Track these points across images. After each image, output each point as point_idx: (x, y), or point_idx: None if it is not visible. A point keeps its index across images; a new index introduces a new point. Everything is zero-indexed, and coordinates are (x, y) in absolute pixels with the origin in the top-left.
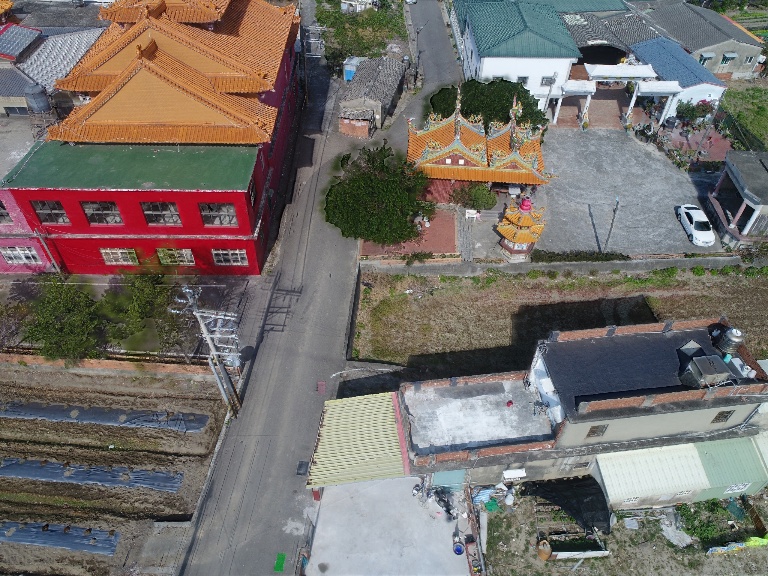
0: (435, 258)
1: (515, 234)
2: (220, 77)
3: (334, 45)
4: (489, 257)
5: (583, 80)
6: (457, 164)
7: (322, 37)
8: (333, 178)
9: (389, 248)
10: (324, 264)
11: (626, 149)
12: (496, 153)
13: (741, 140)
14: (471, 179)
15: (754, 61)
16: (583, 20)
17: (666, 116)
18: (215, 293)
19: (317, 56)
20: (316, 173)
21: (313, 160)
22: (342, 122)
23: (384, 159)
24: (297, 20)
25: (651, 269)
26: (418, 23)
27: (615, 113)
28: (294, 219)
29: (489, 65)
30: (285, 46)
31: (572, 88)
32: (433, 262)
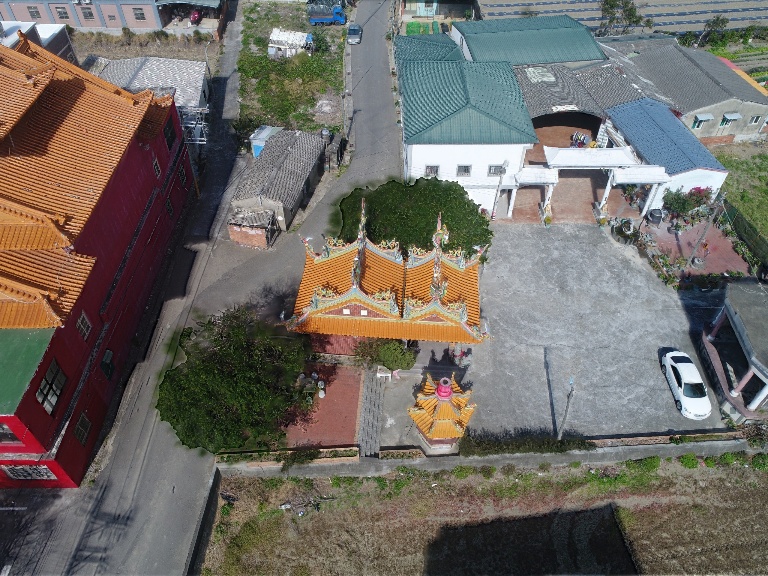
0: (322, 457)
1: (430, 429)
2: (0, 225)
3: (253, 103)
4: (402, 444)
5: (542, 168)
6: (359, 315)
7: (239, 93)
8: (208, 317)
9: (264, 437)
10: (169, 469)
11: (598, 255)
12: (409, 303)
13: (746, 241)
14: (377, 336)
15: (761, 121)
16: (549, 75)
17: (650, 207)
18: (8, 523)
19: (201, 142)
20: (187, 309)
21: (187, 287)
22: (232, 229)
23: (281, 282)
24: (167, 102)
25: (623, 459)
26: (358, 70)
27: (587, 198)
28: (142, 389)
29: (419, 153)
30: (119, 160)
31: (528, 179)
32: (320, 462)
